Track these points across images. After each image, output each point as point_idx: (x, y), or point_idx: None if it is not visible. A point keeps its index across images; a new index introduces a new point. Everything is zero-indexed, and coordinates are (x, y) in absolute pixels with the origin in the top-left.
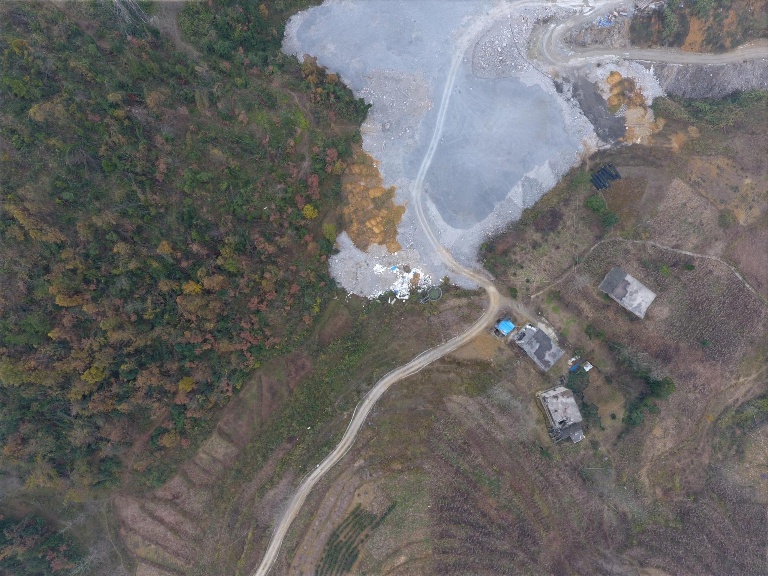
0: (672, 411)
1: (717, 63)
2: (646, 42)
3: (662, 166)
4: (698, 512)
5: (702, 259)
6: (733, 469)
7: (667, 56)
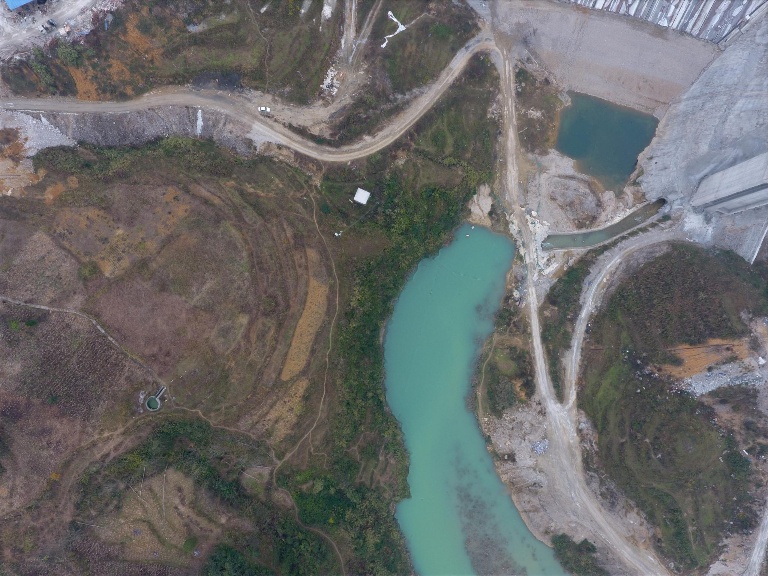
0: (21, 470)
1: (119, 111)
2: (33, 92)
3: (26, 219)
4: (45, 573)
5: (58, 313)
6: (107, 525)
7: (60, 105)
